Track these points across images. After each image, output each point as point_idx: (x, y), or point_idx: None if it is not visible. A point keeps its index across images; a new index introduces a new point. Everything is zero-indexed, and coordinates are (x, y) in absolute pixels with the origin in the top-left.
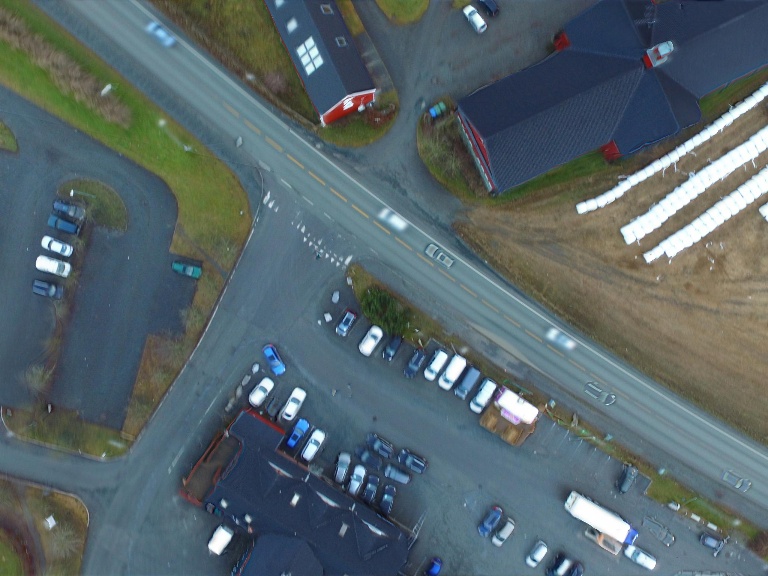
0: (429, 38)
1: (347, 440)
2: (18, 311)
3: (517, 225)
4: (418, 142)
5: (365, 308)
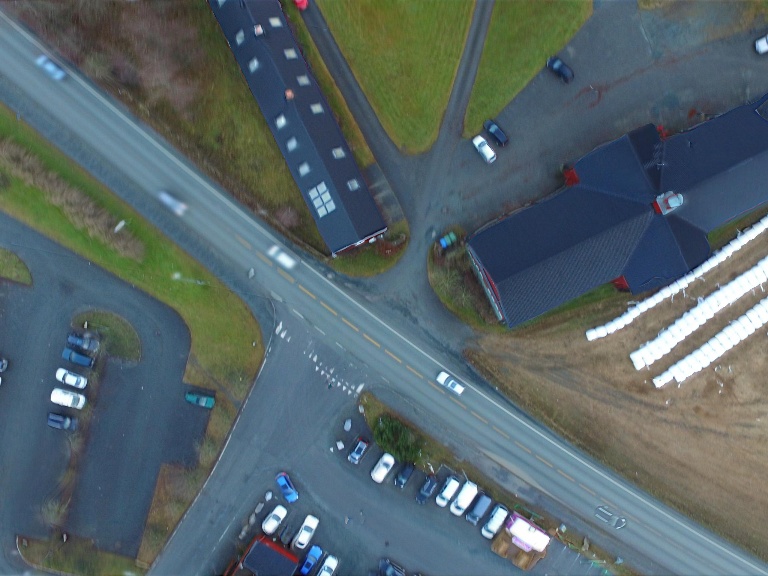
0: (439, 168)
1: (360, 565)
2: (33, 442)
3: (527, 352)
4: (429, 271)
5: (377, 437)
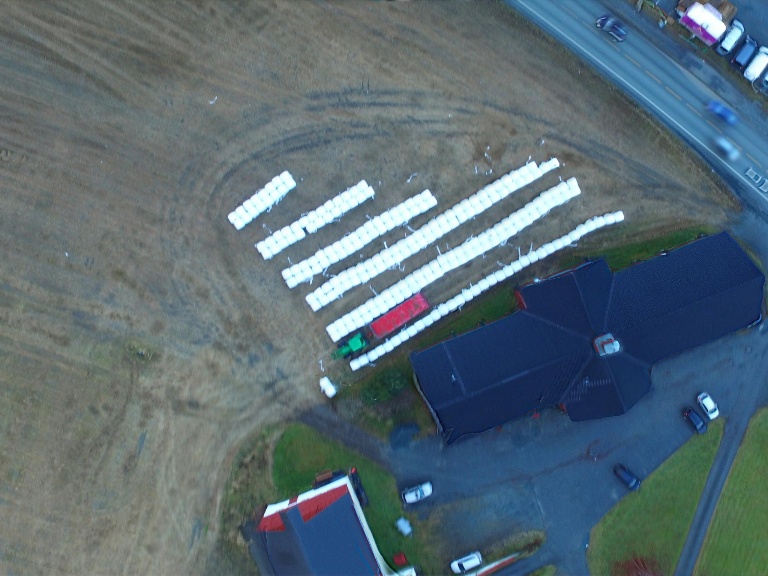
0: (751, 391)
1: None
2: None
3: (681, 205)
4: None
5: None
